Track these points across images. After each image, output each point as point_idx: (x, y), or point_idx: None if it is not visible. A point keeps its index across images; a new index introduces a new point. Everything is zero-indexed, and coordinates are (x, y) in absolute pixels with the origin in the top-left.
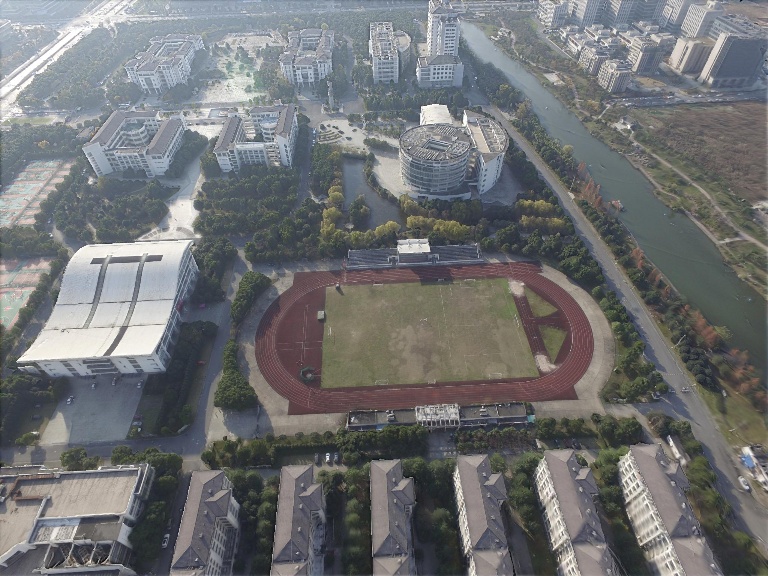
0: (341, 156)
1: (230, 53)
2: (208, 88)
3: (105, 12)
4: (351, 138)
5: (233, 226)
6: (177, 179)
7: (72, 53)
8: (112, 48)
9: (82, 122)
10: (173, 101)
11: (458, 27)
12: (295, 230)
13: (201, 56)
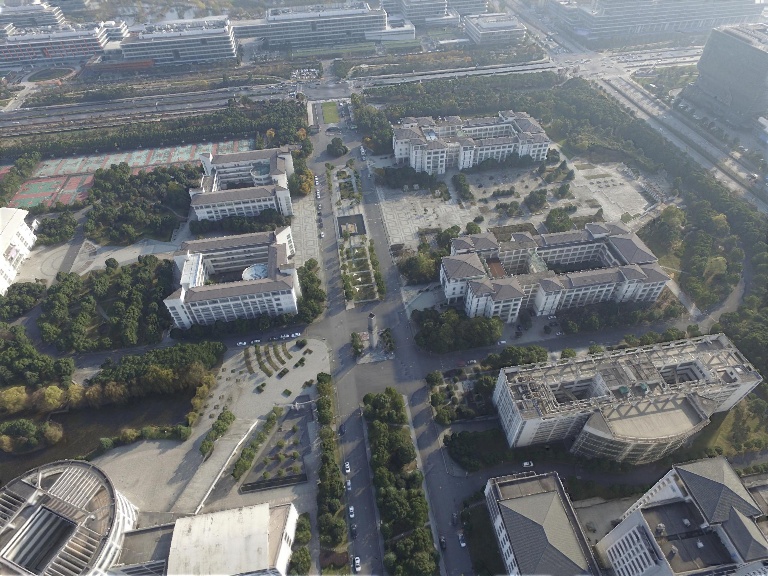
0: (193, 386)
1: (553, 183)
2: (425, 195)
3: (623, 60)
4: (261, 392)
5: (42, 302)
6: (190, 234)
7: (471, 81)
8: (501, 97)
9: (328, 139)
10: (380, 179)
11: (665, 574)
12: (6, 363)
13: (508, 162)
